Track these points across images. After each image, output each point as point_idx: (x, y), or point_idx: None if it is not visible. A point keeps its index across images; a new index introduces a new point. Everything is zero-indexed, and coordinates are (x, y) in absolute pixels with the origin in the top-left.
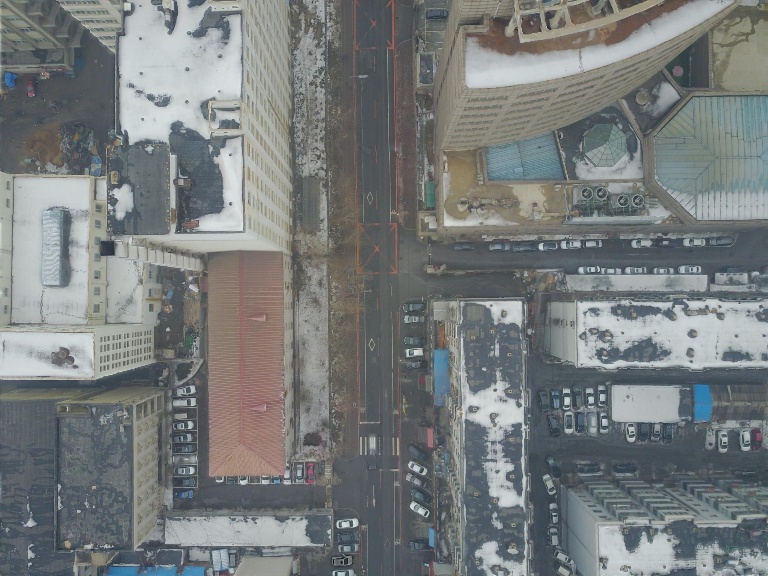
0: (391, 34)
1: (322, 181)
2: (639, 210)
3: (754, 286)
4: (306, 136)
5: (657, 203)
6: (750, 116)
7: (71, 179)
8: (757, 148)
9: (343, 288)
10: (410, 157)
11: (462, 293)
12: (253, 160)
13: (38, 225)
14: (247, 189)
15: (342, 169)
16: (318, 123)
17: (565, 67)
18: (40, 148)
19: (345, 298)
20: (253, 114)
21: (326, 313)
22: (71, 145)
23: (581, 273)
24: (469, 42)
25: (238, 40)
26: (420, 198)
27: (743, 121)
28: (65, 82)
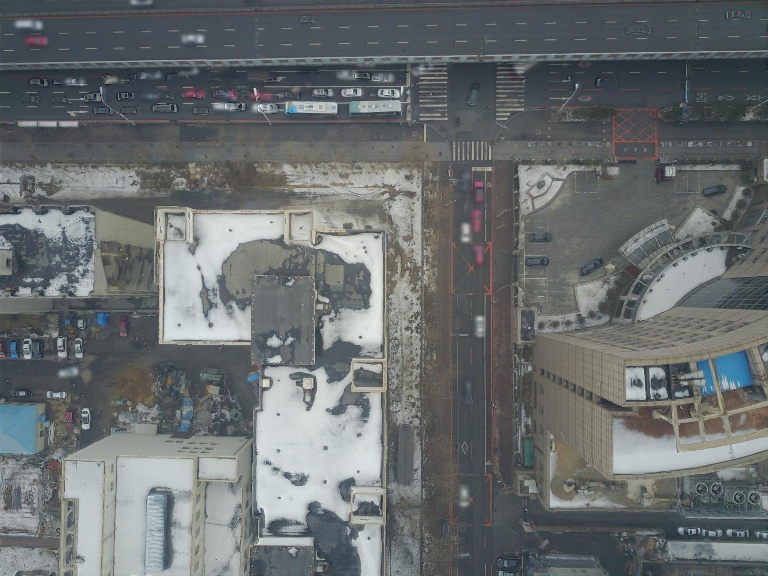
0: (489, 279)
1: (416, 430)
2: (754, 505)
3: None
4: (401, 383)
5: None
6: None
7: (175, 459)
8: None
9: None
10: (507, 407)
11: (558, 549)
12: None
13: (141, 505)
14: None
15: (437, 417)
16: (413, 370)
17: (715, 453)
18: (132, 389)
19: None
20: None
21: (418, 564)
22: (163, 388)
23: (681, 534)
24: (615, 424)
25: (378, 419)
26: (517, 451)
27: None
28: (157, 321)
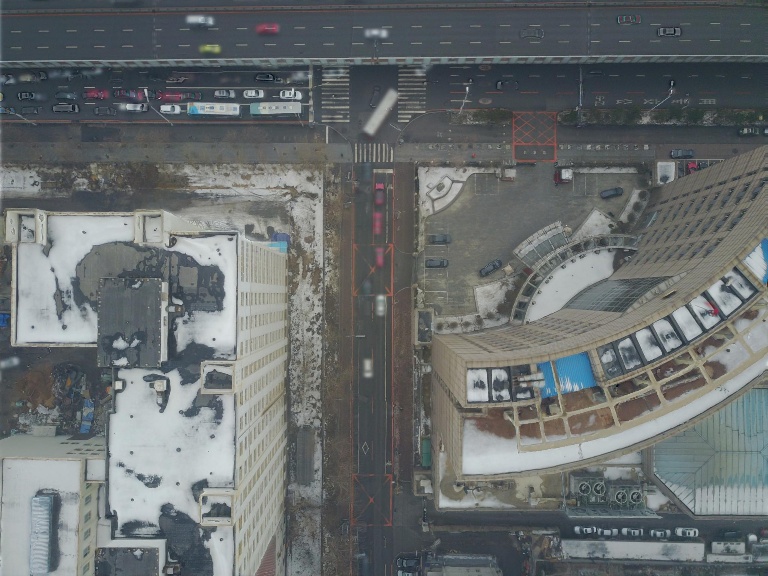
0: (390, 280)
1: (317, 430)
2: (637, 504)
3: (751, 557)
4: (302, 384)
5: (655, 489)
6: (751, 409)
7: (61, 461)
8: (758, 443)
9: (336, 540)
10: (407, 408)
11: (457, 548)
12: (245, 520)
13: (27, 507)
14: (238, 569)
15: (338, 418)
16: (314, 371)
17: (564, 453)
18: (32, 390)
19: (338, 550)
20: (246, 472)
21: (319, 565)
22: (63, 390)
23: (577, 533)
24: (467, 425)
25: (231, 420)
26: (416, 451)
27: (744, 414)
28: None
